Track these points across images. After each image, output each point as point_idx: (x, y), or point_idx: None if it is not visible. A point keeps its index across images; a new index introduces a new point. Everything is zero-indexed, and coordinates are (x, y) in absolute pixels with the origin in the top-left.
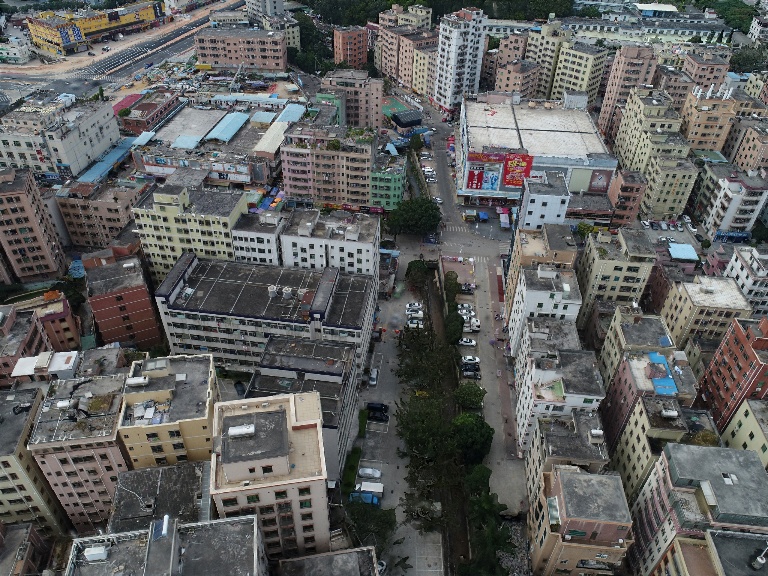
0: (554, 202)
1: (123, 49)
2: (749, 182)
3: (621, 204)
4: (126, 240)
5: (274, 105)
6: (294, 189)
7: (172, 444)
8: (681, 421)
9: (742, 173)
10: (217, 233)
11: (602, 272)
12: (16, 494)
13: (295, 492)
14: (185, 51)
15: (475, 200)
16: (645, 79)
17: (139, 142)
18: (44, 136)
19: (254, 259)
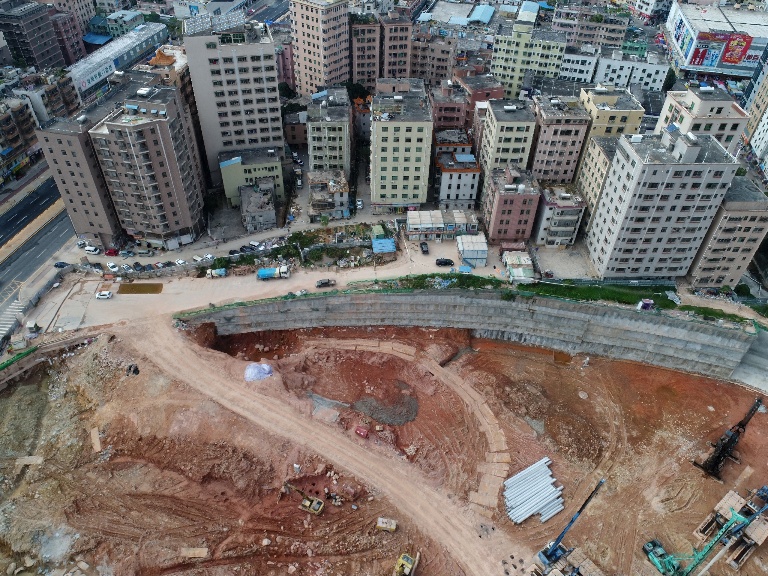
0: None
1: None
2: None
3: None
4: None
5: (510, 2)
6: None
7: (618, 128)
8: None
9: None
10: (552, 56)
11: None
12: (517, 155)
13: (729, 127)
14: None
15: (693, 76)
16: None
17: (423, 19)
18: (364, 7)
19: (572, 79)
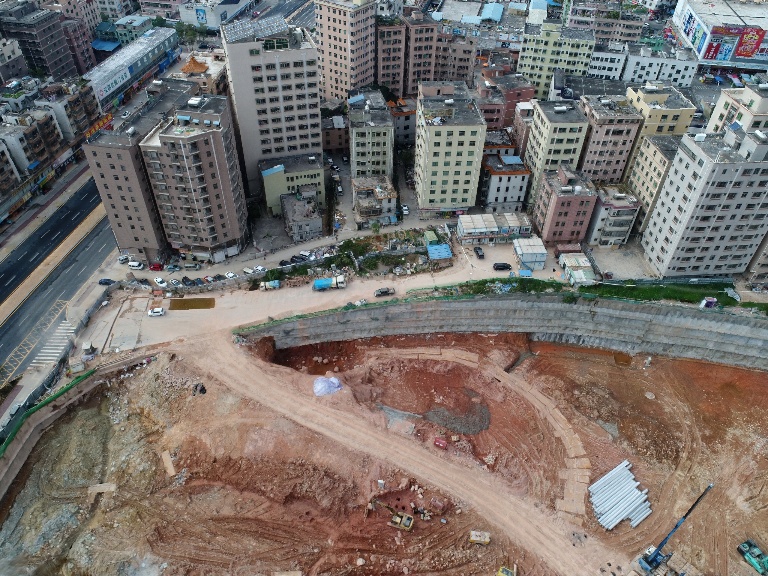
0: None
1: None
2: None
3: None
4: None
5: None
6: None
7: (669, 126)
8: None
9: None
10: (581, 54)
11: None
12: (568, 156)
13: None
14: None
15: (706, 70)
16: None
17: (435, 18)
18: (377, 7)
19: (601, 76)
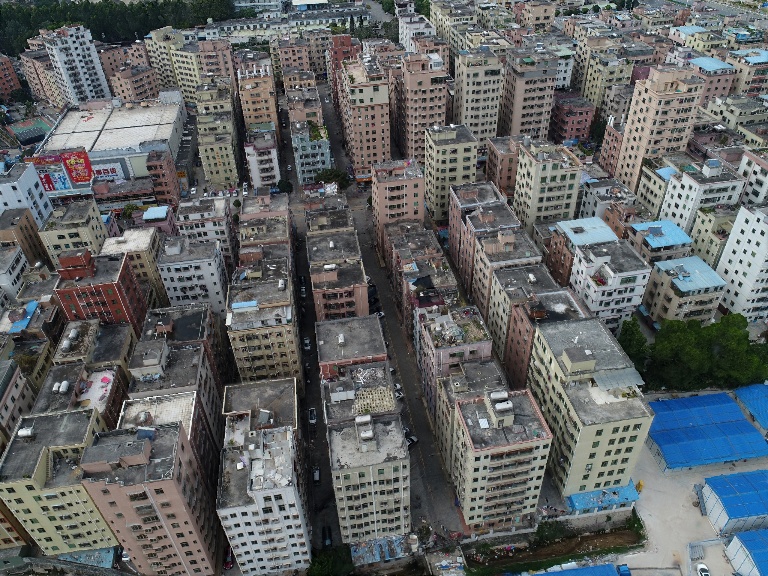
0: (6, 190)
1: None
2: (261, 144)
3: (154, 182)
4: None
5: None
6: None
7: None
8: (1, 351)
9: (262, 138)
10: None
11: (50, 243)
12: None
13: None
14: None
15: (58, 201)
16: (227, 68)
17: None
18: None
19: None
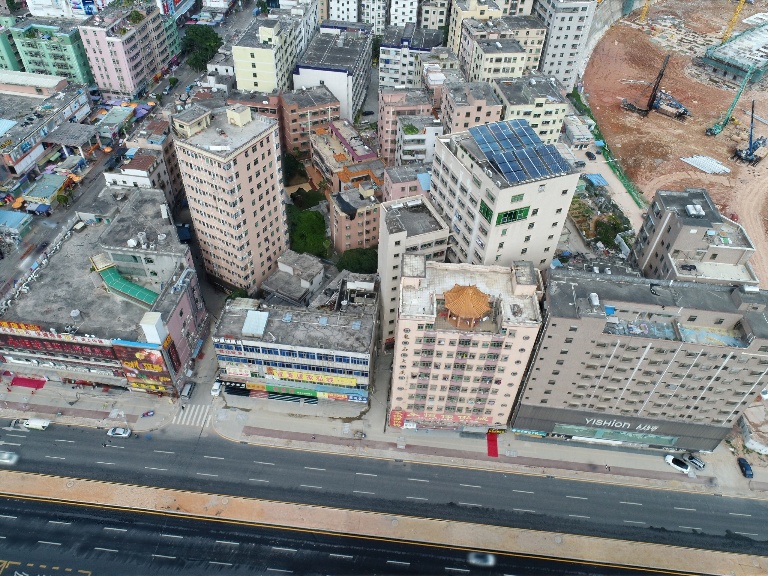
0: None
1: None
2: None
3: None
4: (257, 101)
5: None
6: (137, 78)
7: None
8: None
9: None
10: (292, 40)
11: None
12: None
13: None
14: None
15: None
16: None
17: None
18: None
19: None
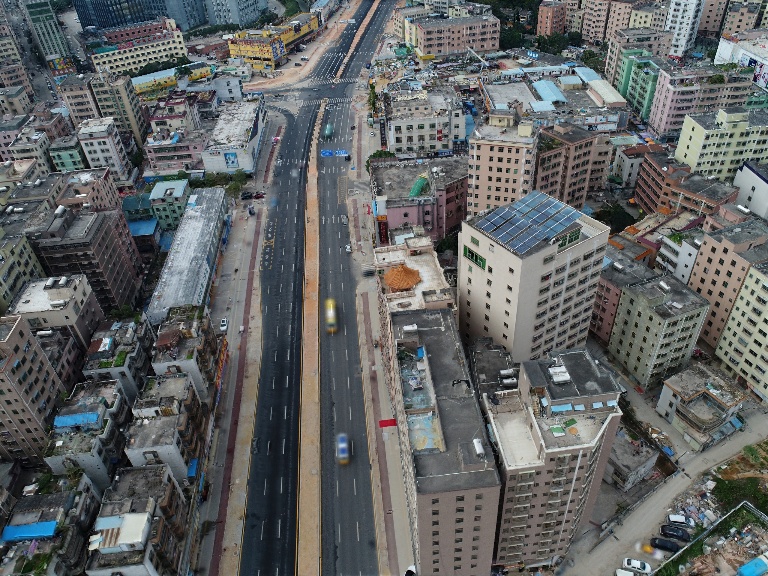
0: None
1: (320, 56)
2: None
3: None
4: (665, 166)
5: None
6: (673, 125)
7: None
8: None
9: None
10: None
11: None
12: None
13: None
14: (378, 50)
15: None
16: None
17: None
18: (451, 115)
19: None
